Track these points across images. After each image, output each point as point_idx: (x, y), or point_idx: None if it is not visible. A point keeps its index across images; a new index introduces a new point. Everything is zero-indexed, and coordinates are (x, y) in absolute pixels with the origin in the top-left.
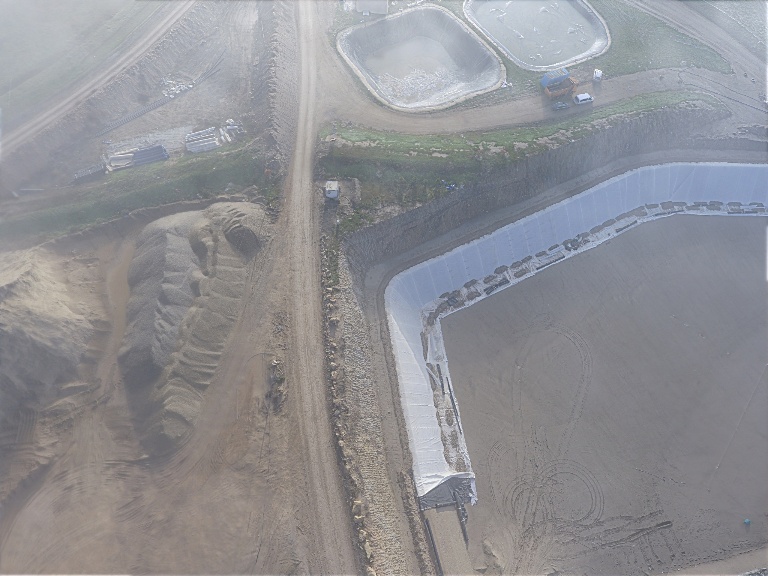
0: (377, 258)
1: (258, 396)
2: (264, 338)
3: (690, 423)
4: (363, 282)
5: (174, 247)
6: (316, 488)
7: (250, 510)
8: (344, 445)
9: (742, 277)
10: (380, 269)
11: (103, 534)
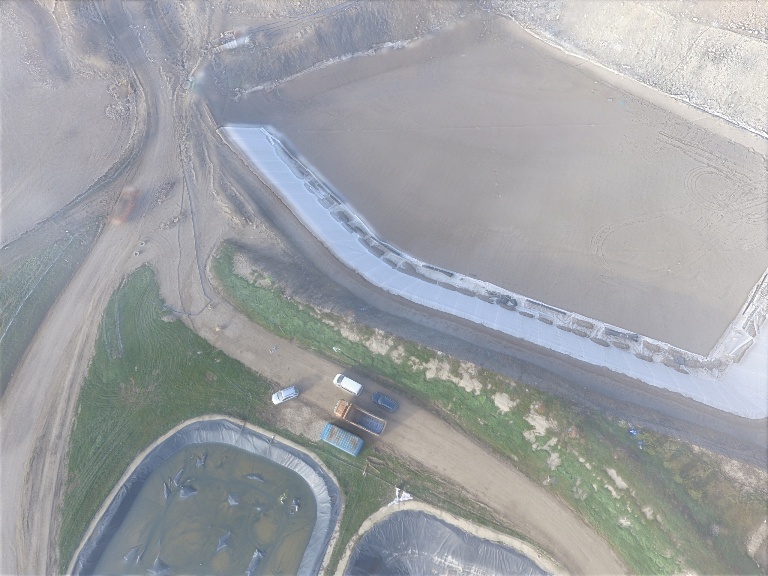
0: (760, 452)
1: None
2: None
3: (579, 150)
4: None
5: None
6: None
7: None
8: None
9: (408, 169)
10: (762, 440)
11: None
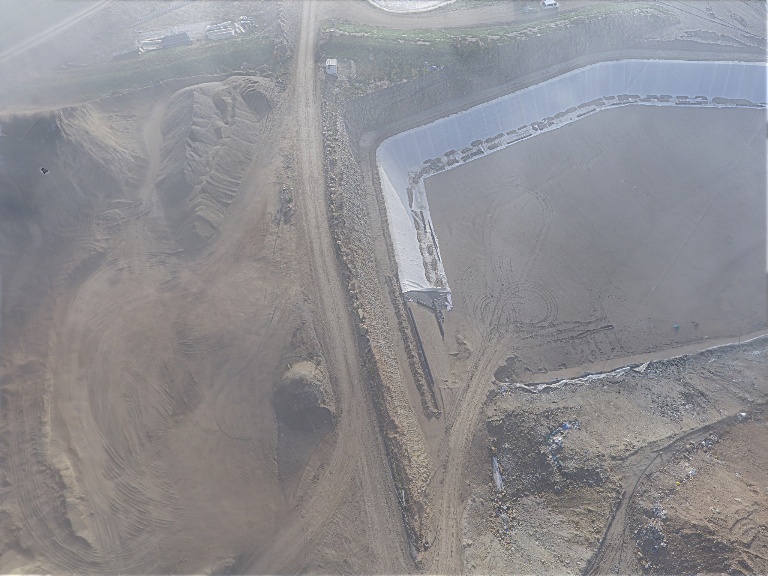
0: (370, 126)
1: (271, 211)
2: (275, 172)
3: (633, 257)
4: (358, 143)
5: (200, 101)
6: (319, 273)
7: (266, 287)
8: (342, 244)
9: (685, 152)
10: (372, 134)
11: (149, 300)
